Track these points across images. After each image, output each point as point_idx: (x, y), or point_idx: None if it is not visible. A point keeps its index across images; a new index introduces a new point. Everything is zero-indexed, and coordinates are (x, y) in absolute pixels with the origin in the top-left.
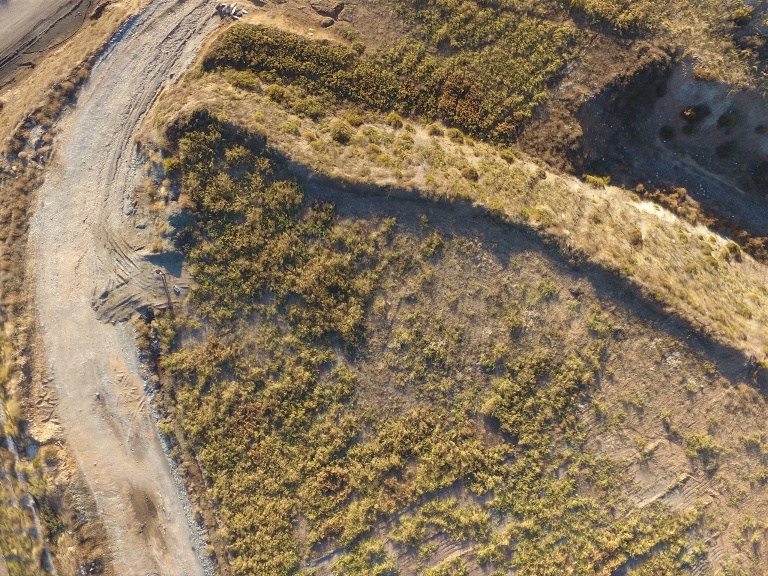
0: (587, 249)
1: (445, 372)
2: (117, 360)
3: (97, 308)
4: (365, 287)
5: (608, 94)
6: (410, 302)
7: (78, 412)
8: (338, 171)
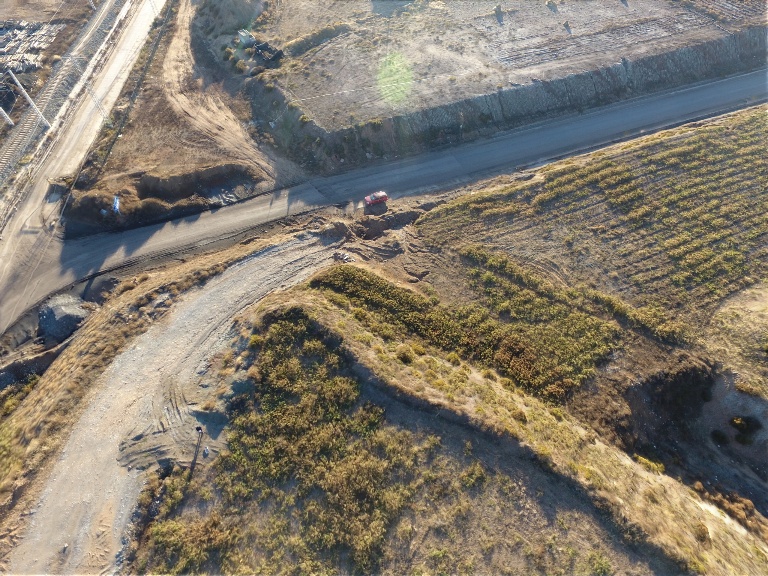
0: (645, 526)
1: None
2: (110, 510)
3: (124, 448)
4: (394, 502)
5: (654, 385)
6: (439, 535)
7: (33, 562)
8: (396, 381)
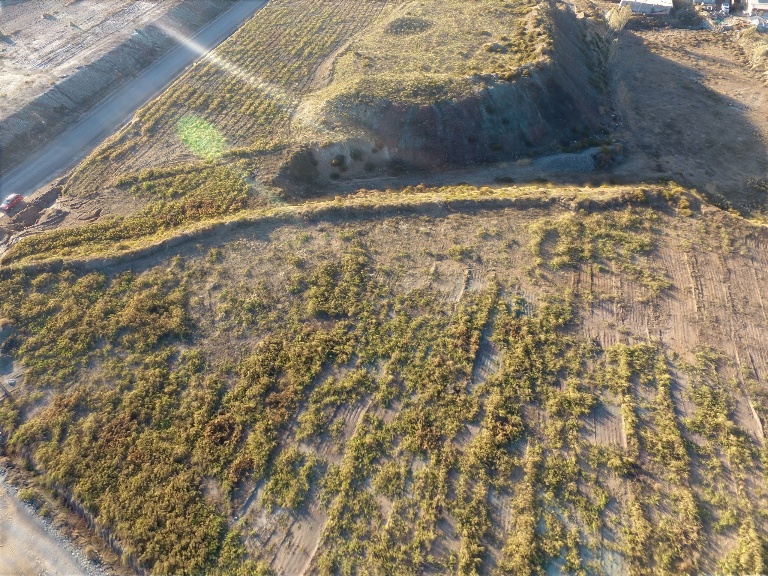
0: (310, 209)
1: (267, 309)
2: None
3: None
4: (177, 296)
5: (284, 172)
6: (217, 289)
7: None
8: None
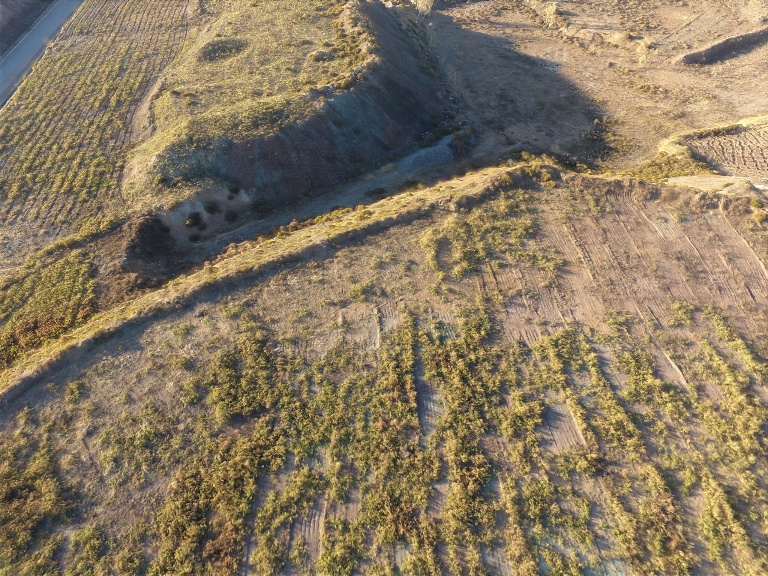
0: (179, 294)
1: (167, 436)
2: None
3: None
4: (41, 464)
5: (132, 251)
6: (93, 433)
7: None
8: None
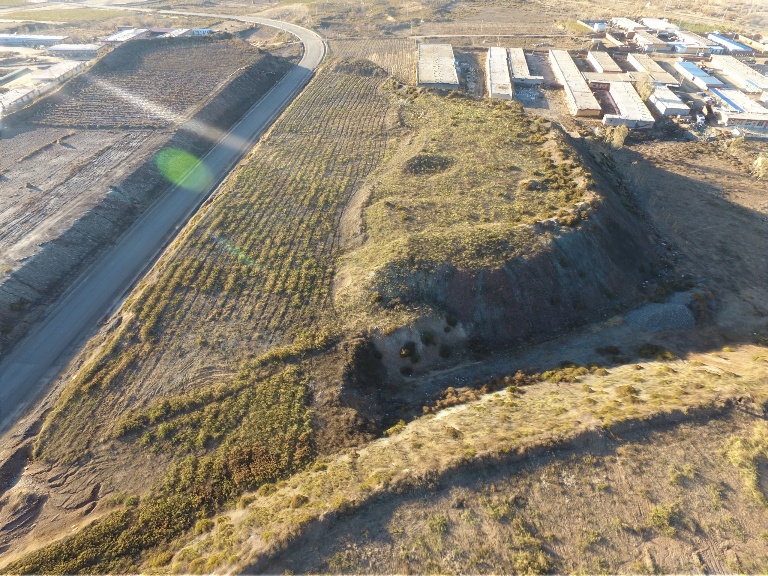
0: (431, 467)
1: None
2: None
3: None
4: None
5: (349, 379)
6: None
7: None
8: None
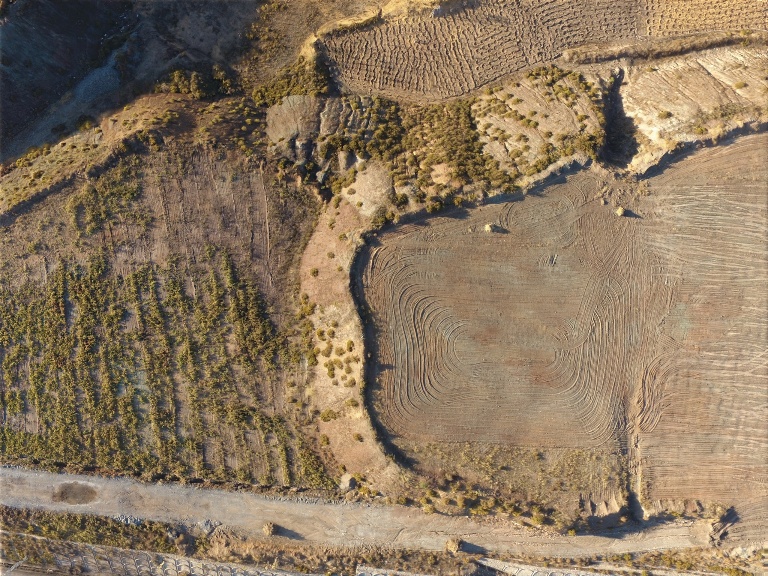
0: None
1: None
2: None
3: None
4: None
5: None
6: None
7: None
8: None
